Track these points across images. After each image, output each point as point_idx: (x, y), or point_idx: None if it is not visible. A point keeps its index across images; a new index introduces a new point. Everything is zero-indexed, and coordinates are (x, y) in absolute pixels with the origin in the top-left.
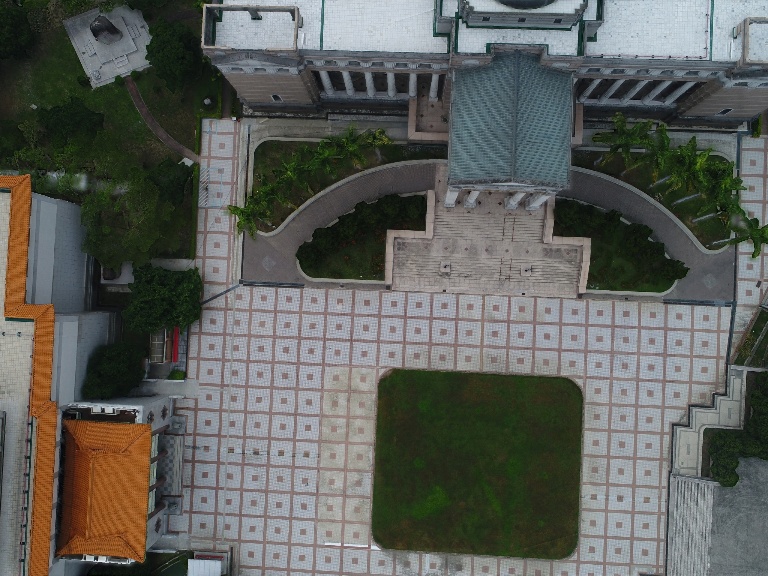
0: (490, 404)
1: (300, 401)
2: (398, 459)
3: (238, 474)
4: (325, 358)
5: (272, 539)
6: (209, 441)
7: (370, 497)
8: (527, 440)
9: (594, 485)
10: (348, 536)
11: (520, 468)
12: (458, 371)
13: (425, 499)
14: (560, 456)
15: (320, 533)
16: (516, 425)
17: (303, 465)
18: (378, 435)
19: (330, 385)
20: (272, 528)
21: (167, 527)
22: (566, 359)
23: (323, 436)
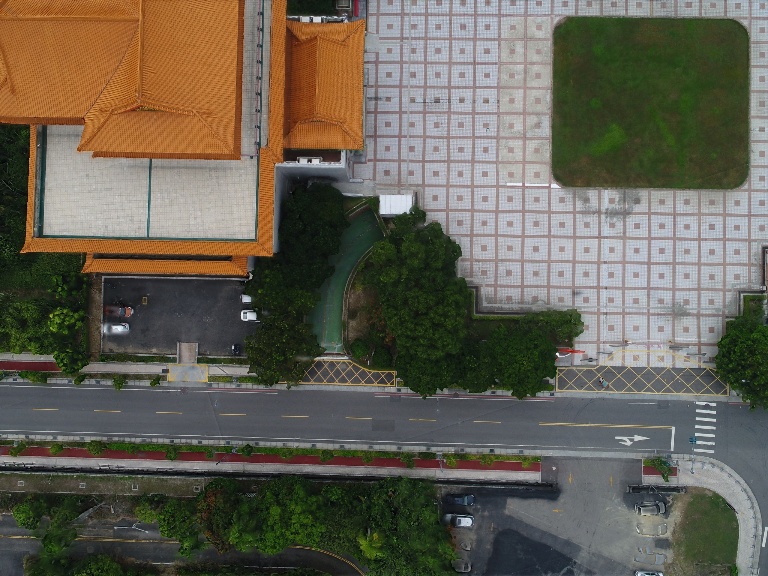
0: (661, 46)
1: (478, 50)
2: (575, 101)
3: (420, 122)
4: (501, 9)
5: (455, 182)
6: (391, 92)
7: (549, 138)
8: (698, 78)
9: (762, 118)
10: (529, 176)
11: (692, 104)
12: (629, 17)
13: (602, 137)
14: (729, 92)
15: (502, 174)
16: (687, 64)
17: (483, 111)
18: (555, 79)
19: (507, 34)
20: (455, 172)
21: (352, 175)
22: (732, 2)
23: (502, 82)
